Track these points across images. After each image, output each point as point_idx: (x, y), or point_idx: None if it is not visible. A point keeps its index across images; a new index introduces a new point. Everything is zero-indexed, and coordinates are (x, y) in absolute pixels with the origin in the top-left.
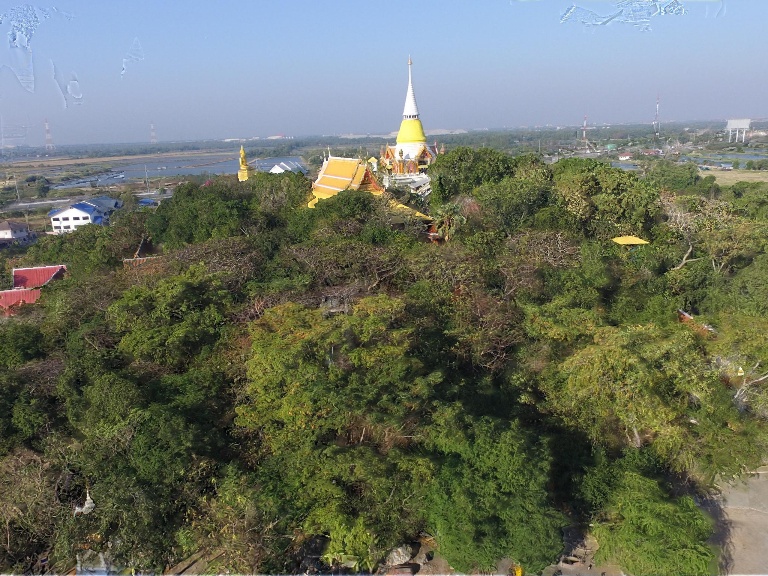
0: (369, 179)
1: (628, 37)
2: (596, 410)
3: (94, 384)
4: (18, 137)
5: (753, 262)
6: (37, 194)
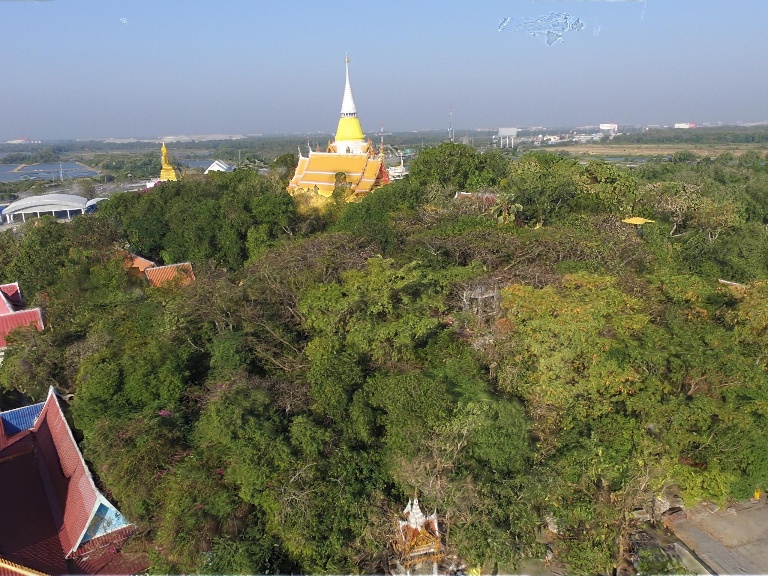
0: (381, 173)
1: None
2: (762, 352)
3: (363, 389)
4: None
5: (739, 233)
6: None
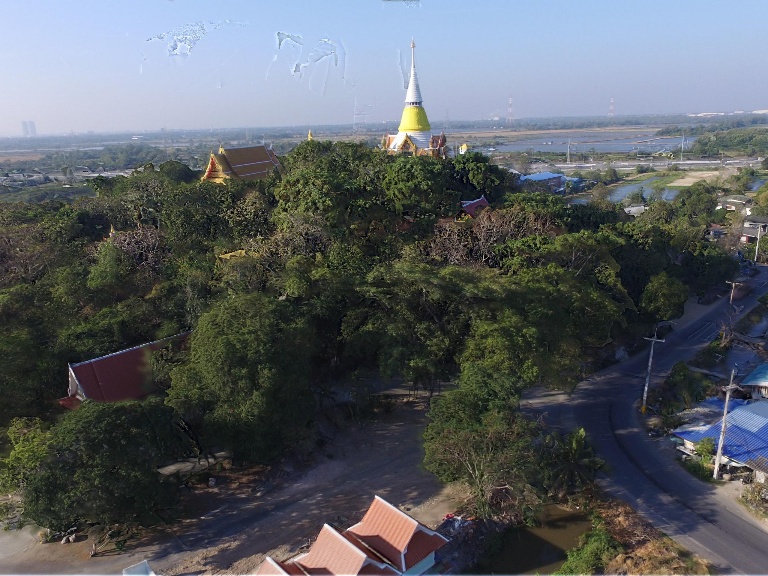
0: None
1: None
2: None
3: None
4: (365, 114)
5: None
6: None
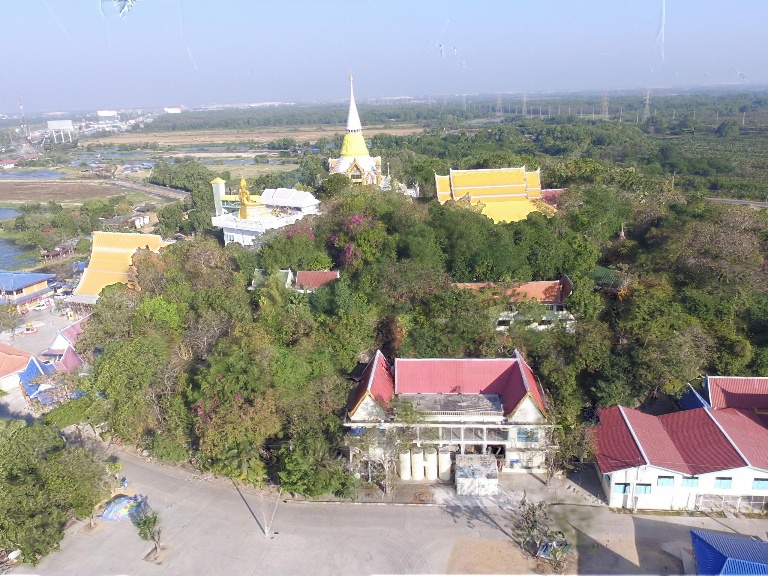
0: None
1: None
2: None
3: None
4: None
5: None
6: None
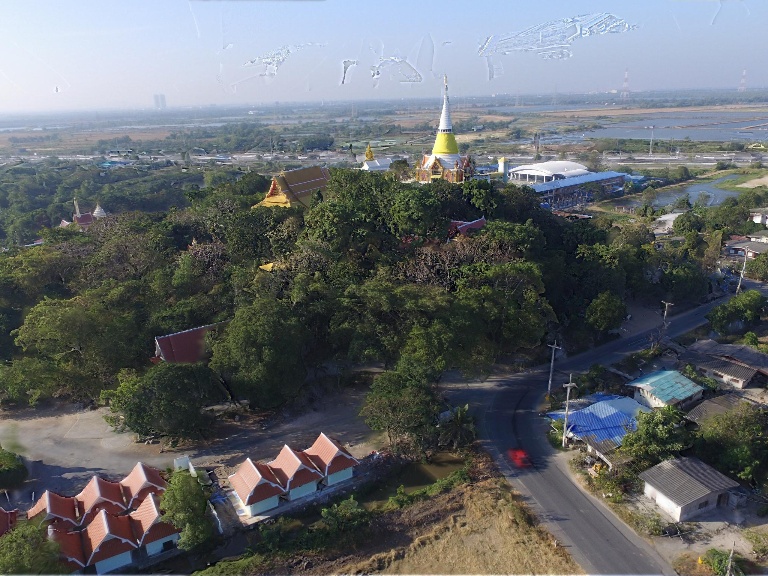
0: None
1: (532, 66)
2: None
3: None
4: (450, 105)
5: None
6: (460, 150)
